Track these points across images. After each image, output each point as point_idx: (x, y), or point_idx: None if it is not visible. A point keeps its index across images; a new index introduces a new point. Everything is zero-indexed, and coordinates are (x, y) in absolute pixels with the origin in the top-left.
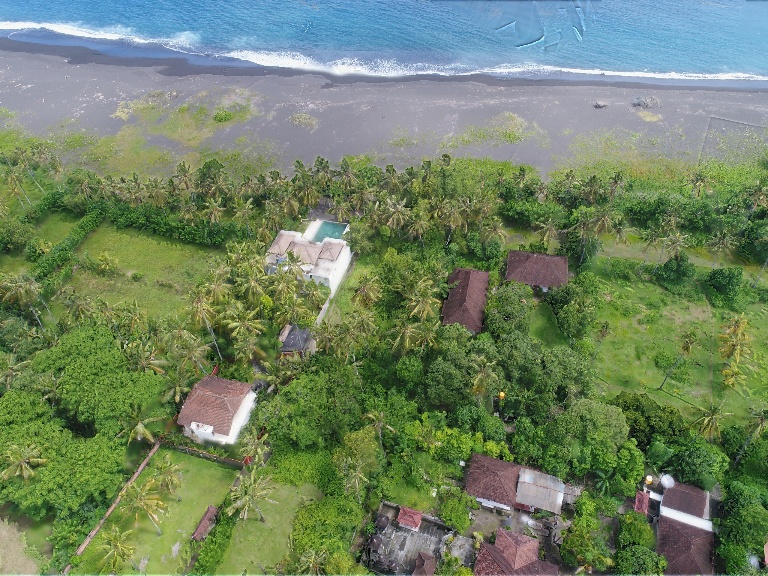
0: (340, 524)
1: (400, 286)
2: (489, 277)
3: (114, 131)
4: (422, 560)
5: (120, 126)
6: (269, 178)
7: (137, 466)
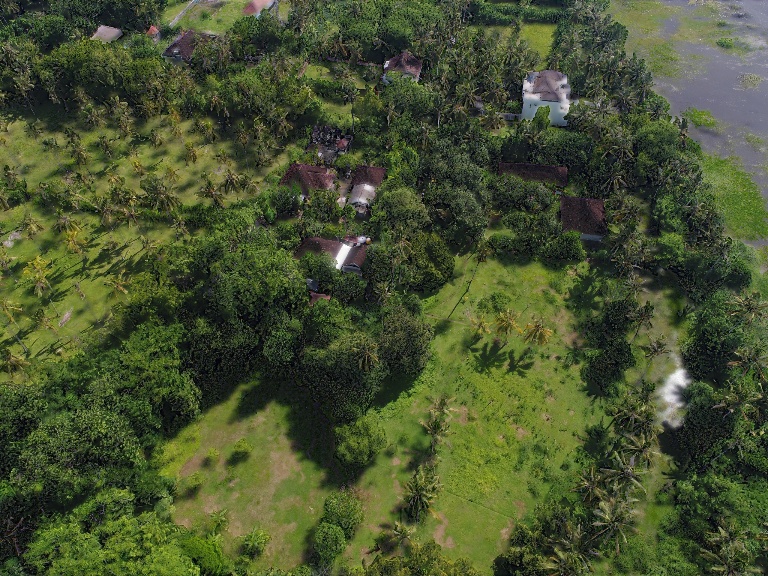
0: (339, 122)
1: None
2: (567, 192)
3: (670, 4)
4: None
5: (678, 5)
6: None
7: (371, 62)
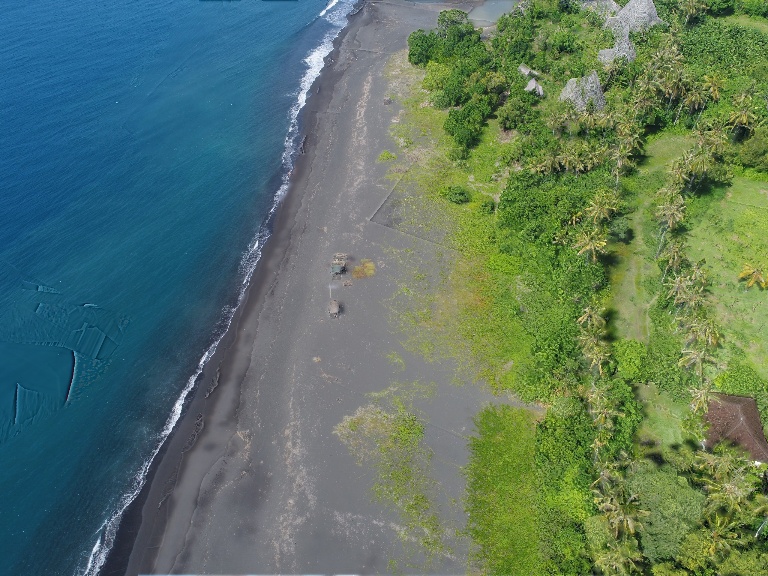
0: None
1: None
2: (761, 487)
3: None
4: None
5: None
6: None
7: None
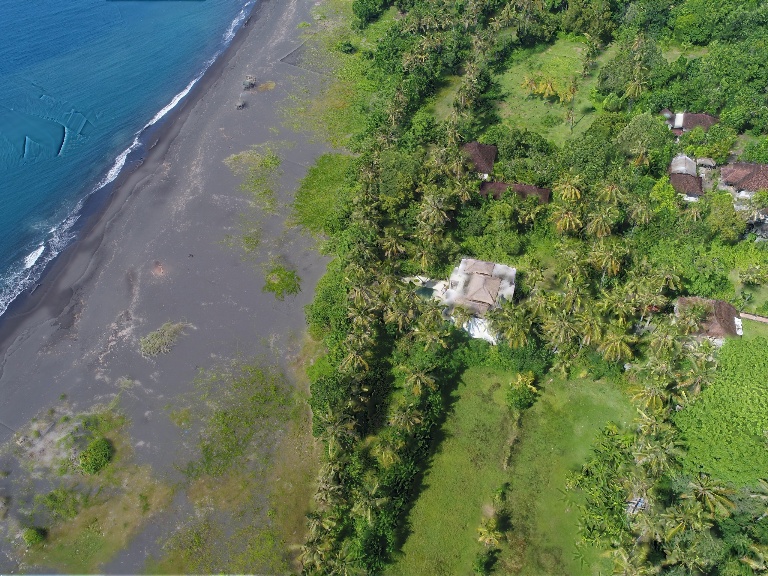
0: (759, 252)
1: (527, 217)
2: None
3: None
4: (766, 209)
5: None
6: (291, 370)
7: None
